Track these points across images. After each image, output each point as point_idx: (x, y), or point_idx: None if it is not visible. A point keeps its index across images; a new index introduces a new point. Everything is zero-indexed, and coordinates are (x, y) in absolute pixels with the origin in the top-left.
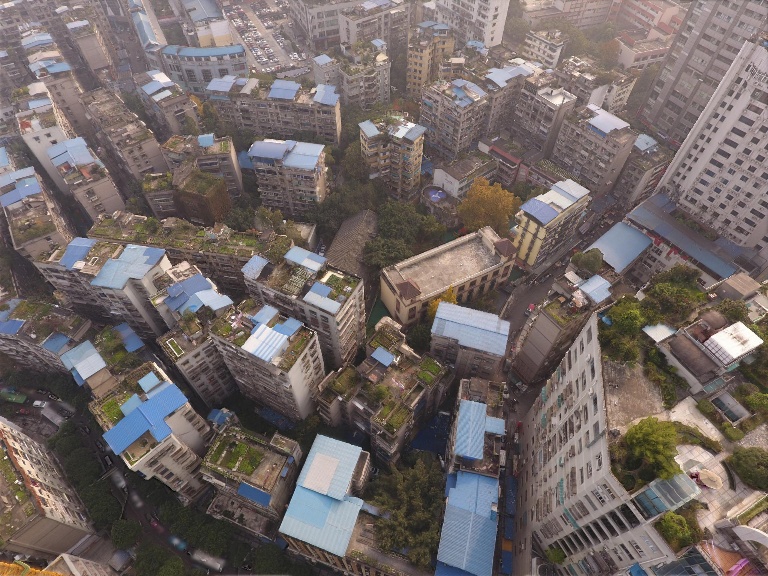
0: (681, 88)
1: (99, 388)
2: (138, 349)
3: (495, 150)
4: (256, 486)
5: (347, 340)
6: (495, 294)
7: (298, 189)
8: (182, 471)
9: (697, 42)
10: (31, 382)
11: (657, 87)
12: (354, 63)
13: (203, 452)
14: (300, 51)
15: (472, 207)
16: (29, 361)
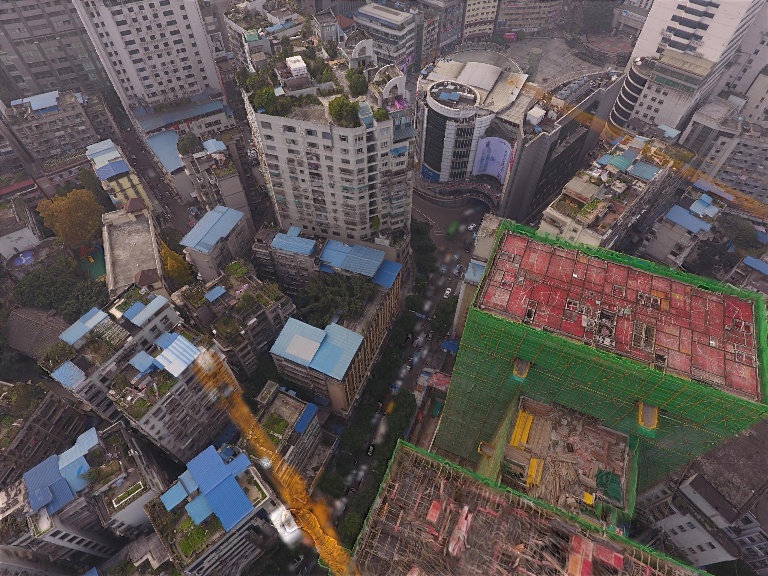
0: (30, 58)
1: None
2: (98, 575)
3: (1, 194)
4: None
5: None
6: (174, 233)
7: None
8: None
9: None
10: None
11: (12, 72)
12: None
13: None
14: None
15: (70, 222)
16: None
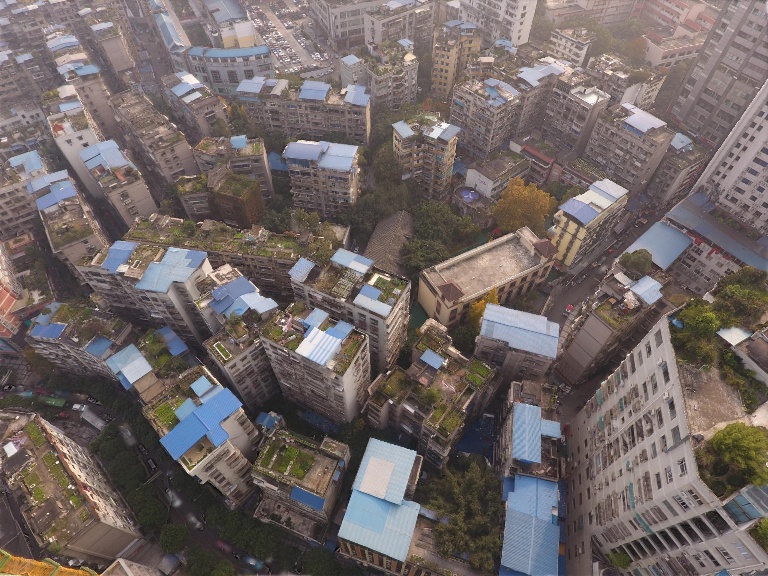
0: (714, 86)
1: (147, 392)
2: (182, 352)
3: (527, 150)
4: (309, 490)
5: (393, 343)
6: (535, 295)
7: (332, 190)
8: (233, 475)
9: (732, 39)
10: (69, 385)
11: (688, 85)
12: (382, 63)
13: (251, 456)
14: (322, 51)
15: (508, 207)
16: (68, 364)
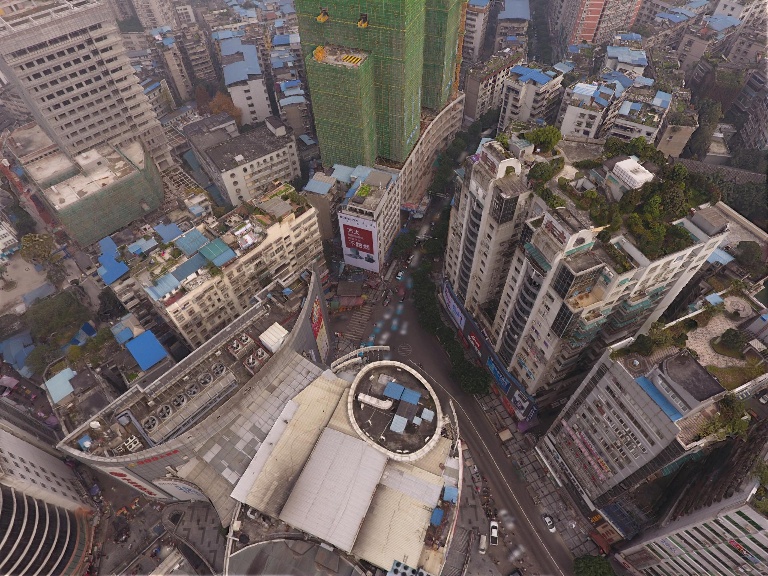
0: None
1: None
2: None
3: None
4: None
5: None
6: None
7: (764, 131)
8: None
9: None
10: None
11: None
12: None
13: None
14: None
15: None
16: None
